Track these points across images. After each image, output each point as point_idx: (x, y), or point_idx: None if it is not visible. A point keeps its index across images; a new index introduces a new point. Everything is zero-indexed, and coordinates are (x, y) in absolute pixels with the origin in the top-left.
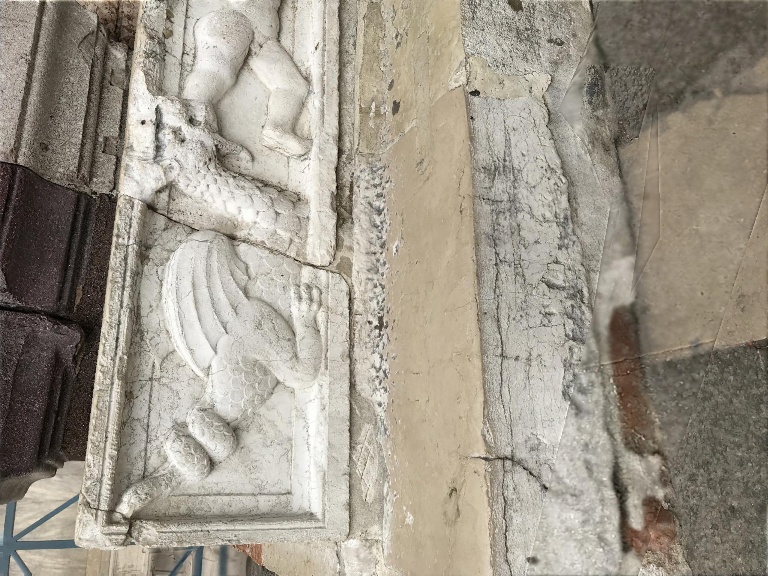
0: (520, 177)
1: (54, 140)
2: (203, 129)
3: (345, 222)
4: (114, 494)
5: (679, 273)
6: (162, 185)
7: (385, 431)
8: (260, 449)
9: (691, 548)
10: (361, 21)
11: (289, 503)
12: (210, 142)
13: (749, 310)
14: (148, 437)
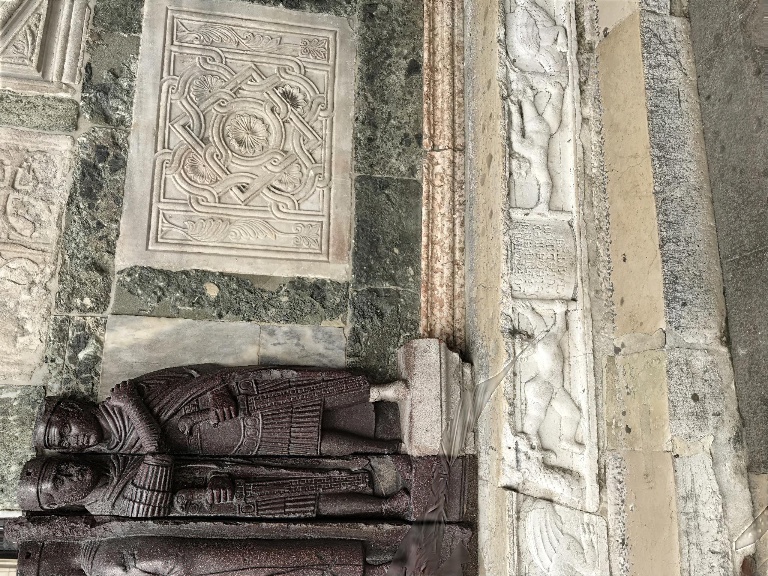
0: (699, 499)
1: None
2: (537, 451)
3: (603, 488)
4: None
5: None
6: None
7: None
8: None
9: None
10: (604, 369)
11: None
12: (540, 457)
13: None
14: None
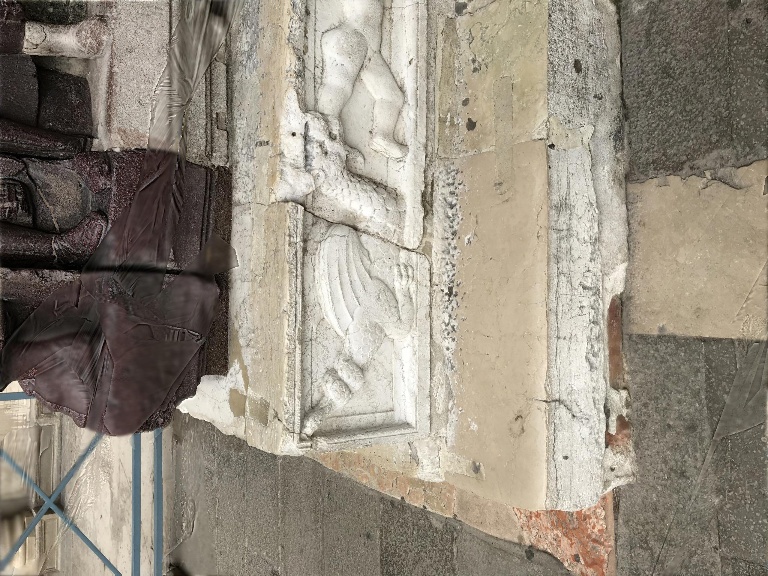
0: (574, 211)
1: (188, 123)
2: (340, 143)
3: (428, 214)
4: (300, 422)
5: (760, 400)
6: (312, 190)
7: (452, 367)
8: (375, 382)
9: (638, 443)
10: (440, 35)
11: (393, 417)
12: (344, 153)
13: (702, 318)
14: (312, 380)
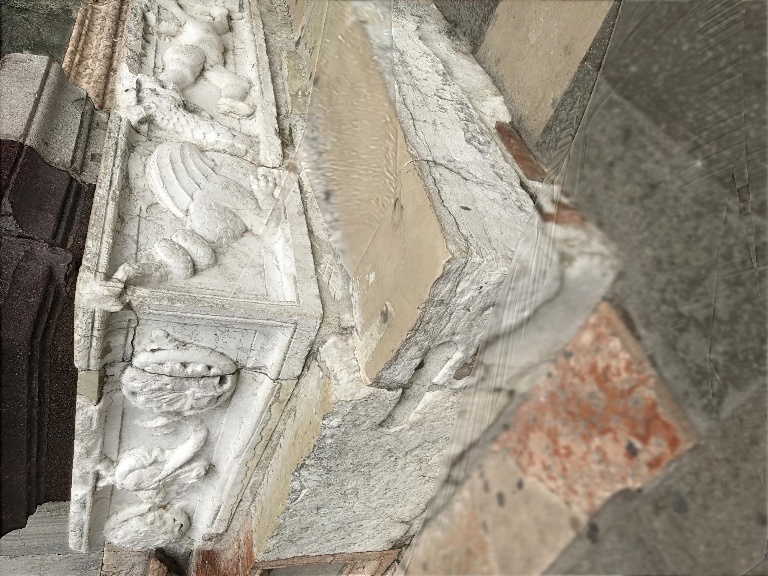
0: (405, 54)
1: (53, 143)
2: (172, 90)
3: (288, 146)
4: (110, 268)
5: None
6: (143, 116)
7: None
8: (236, 268)
9: None
10: (284, 59)
11: None
12: (178, 97)
13: (572, 49)
14: (138, 248)
